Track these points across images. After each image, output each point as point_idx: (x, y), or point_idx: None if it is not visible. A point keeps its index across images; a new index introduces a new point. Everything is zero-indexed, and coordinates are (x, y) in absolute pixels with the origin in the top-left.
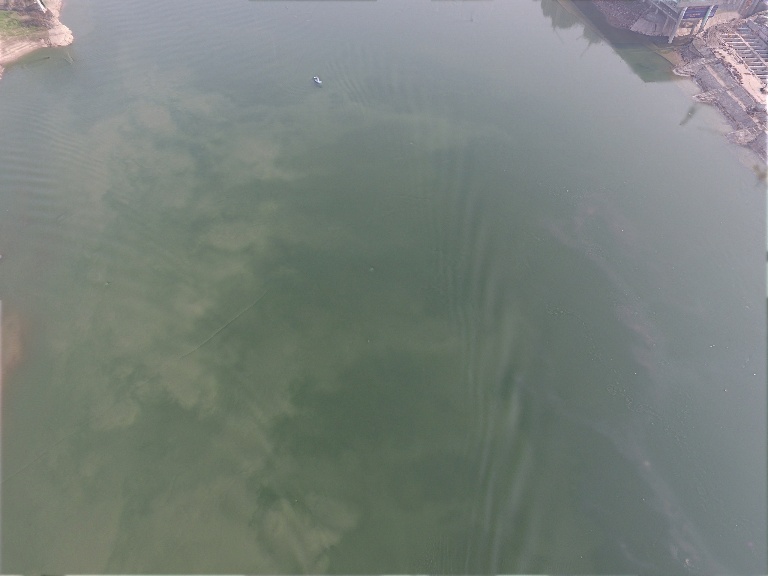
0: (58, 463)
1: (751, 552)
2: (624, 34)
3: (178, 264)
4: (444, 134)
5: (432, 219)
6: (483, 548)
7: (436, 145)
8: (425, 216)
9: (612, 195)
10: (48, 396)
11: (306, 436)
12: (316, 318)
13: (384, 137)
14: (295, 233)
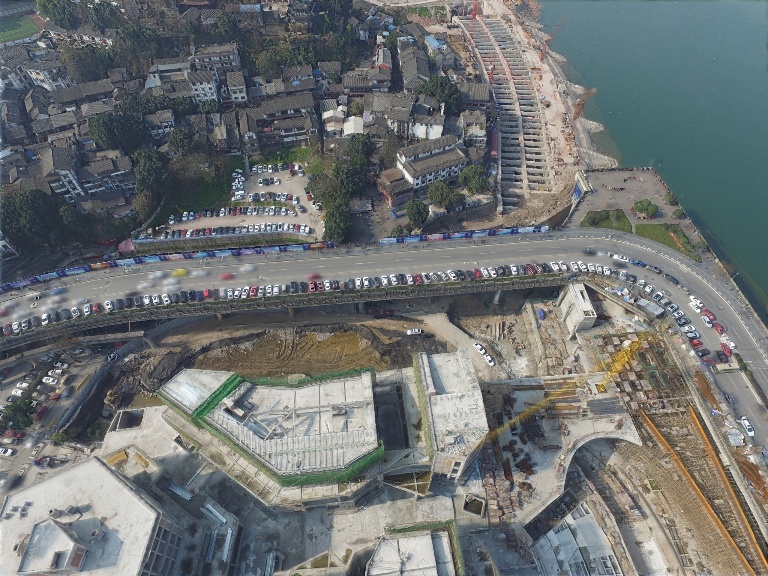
0: None
1: None
2: None
3: None
4: None
5: None
6: None
7: None
8: None
9: (681, 59)
10: None
11: None
12: None
13: None
14: None
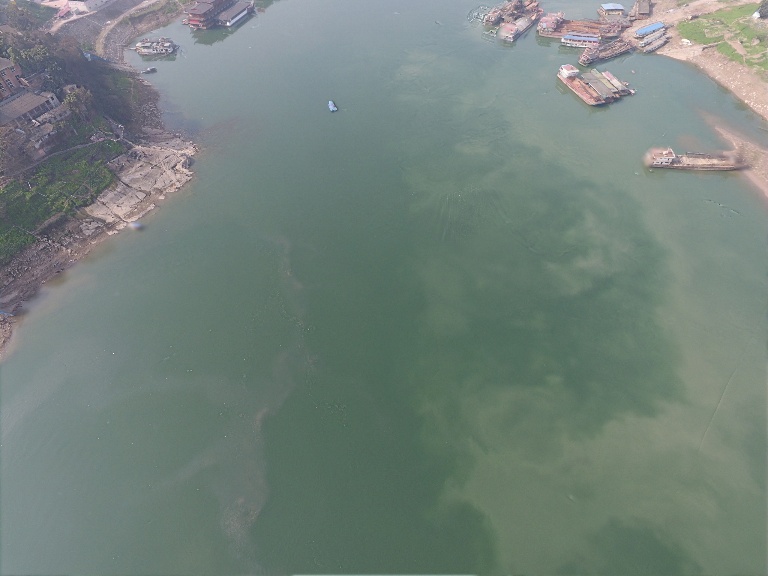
0: (757, 279)
1: (271, 242)
2: None
3: None
4: None
5: None
6: (434, 238)
7: None
8: None
9: None
10: None
11: (572, 305)
12: (616, 417)
13: None
14: None
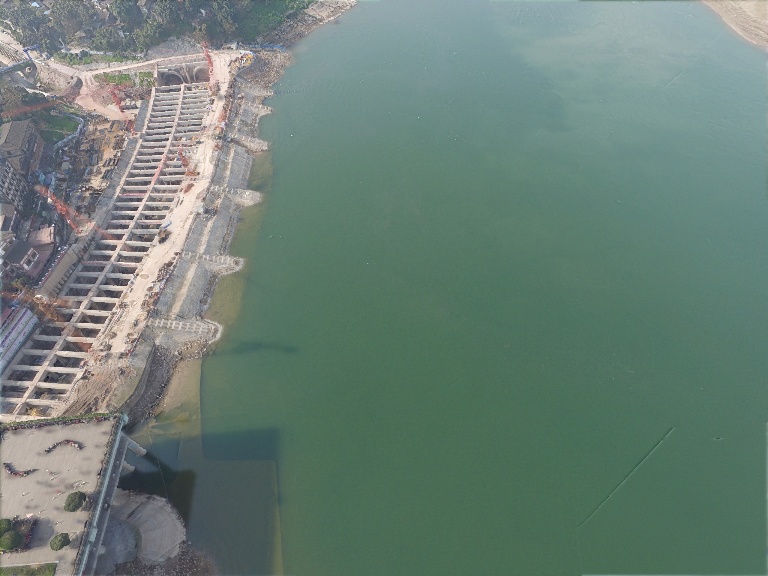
0: None
1: None
2: (216, 512)
3: (745, 106)
4: (585, 210)
5: (570, 116)
6: None
7: (590, 198)
8: (576, 117)
9: (416, 141)
10: (736, 52)
11: (597, 50)
12: None
13: (657, 210)
14: (676, 122)
